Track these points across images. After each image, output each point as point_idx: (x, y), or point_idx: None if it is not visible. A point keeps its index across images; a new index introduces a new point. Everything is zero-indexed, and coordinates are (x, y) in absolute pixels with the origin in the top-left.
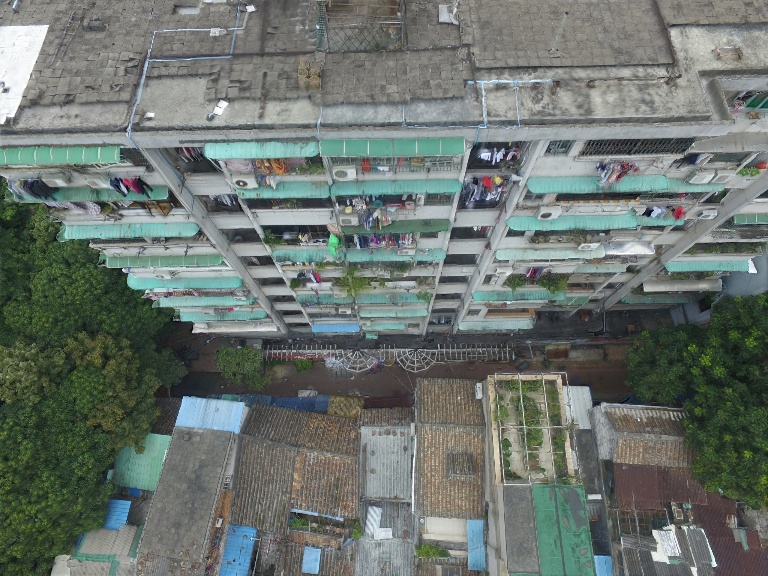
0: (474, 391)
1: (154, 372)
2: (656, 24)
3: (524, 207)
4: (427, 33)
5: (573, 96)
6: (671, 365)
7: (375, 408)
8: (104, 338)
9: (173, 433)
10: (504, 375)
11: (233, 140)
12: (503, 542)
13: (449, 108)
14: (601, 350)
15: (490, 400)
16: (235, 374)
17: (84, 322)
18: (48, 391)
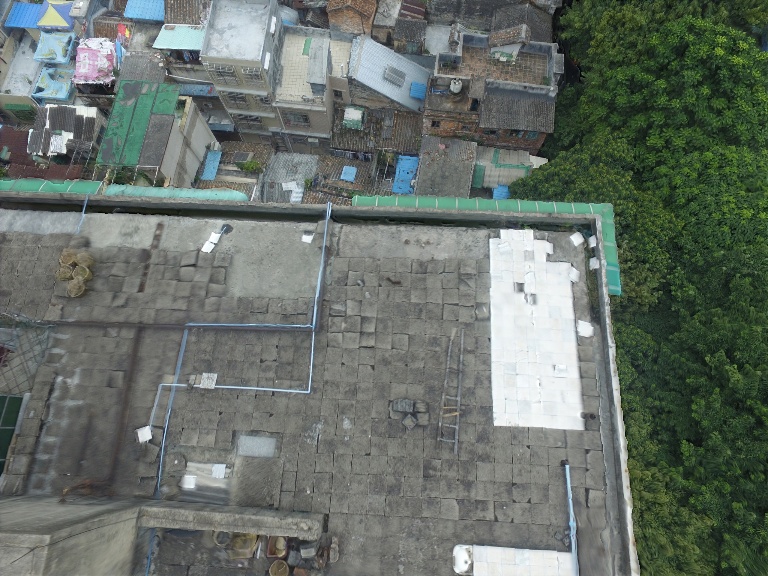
0: None
1: None
2: None
3: None
4: None
5: None
6: None
7: None
8: None
9: None
10: None
11: None
12: (177, 141)
13: None
14: None
15: None
16: None
17: None
18: None
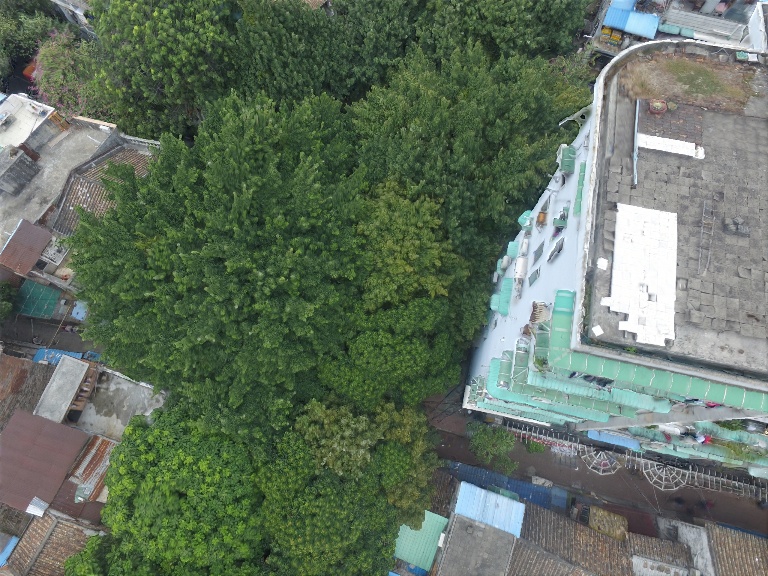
0: None
1: (434, 448)
2: None
3: None
4: None
5: None
6: None
7: (644, 535)
8: (412, 415)
9: (455, 521)
10: None
11: None
12: None
13: None
14: None
15: None
16: (488, 454)
17: None
18: (364, 463)
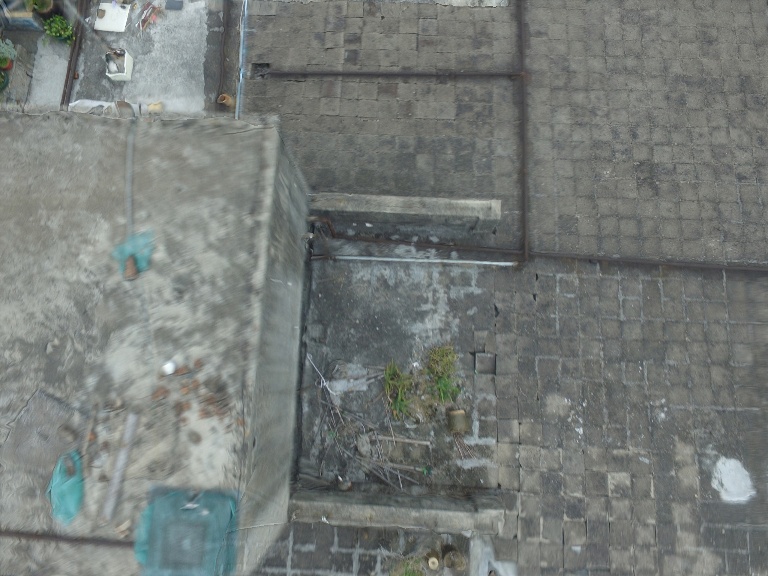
0: None
1: None
2: (531, 5)
3: None
4: None
5: None
6: None
7: None
8: None
9: None
10: None
11: None
12: None
13: None
14: None
15: None
16: None
17: None
18: None
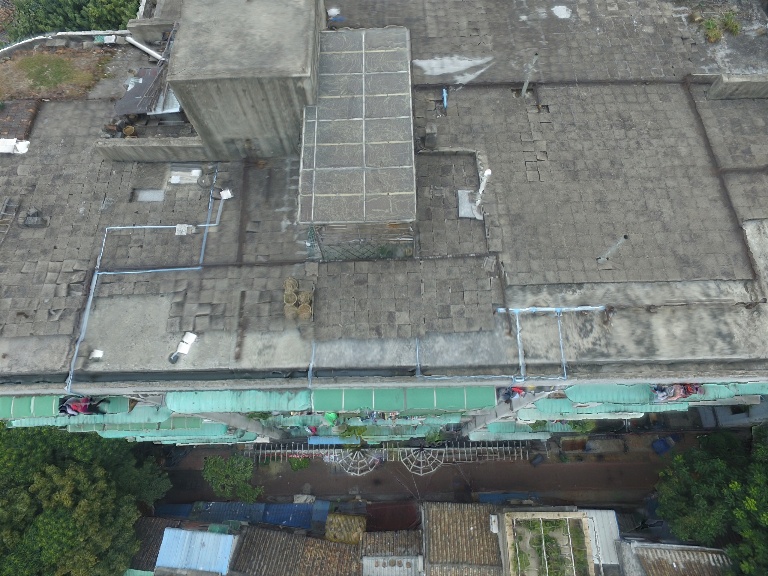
0: (488, 519)
1: (133, 499)
2: (728, 220)
3: (557, 397)
4: (444, 231)
5: (630, 326)
6: (711, 506)
7: (378, 531)
8: (75, 473)
9: (153, 575)
10: (523, 513)
11: (202, 390)
12: None
13: (475, 344)
14: (621, 441)
15: (508, 544)
16: (224, 486)
17: (53, 449)
18: (10, 543)
